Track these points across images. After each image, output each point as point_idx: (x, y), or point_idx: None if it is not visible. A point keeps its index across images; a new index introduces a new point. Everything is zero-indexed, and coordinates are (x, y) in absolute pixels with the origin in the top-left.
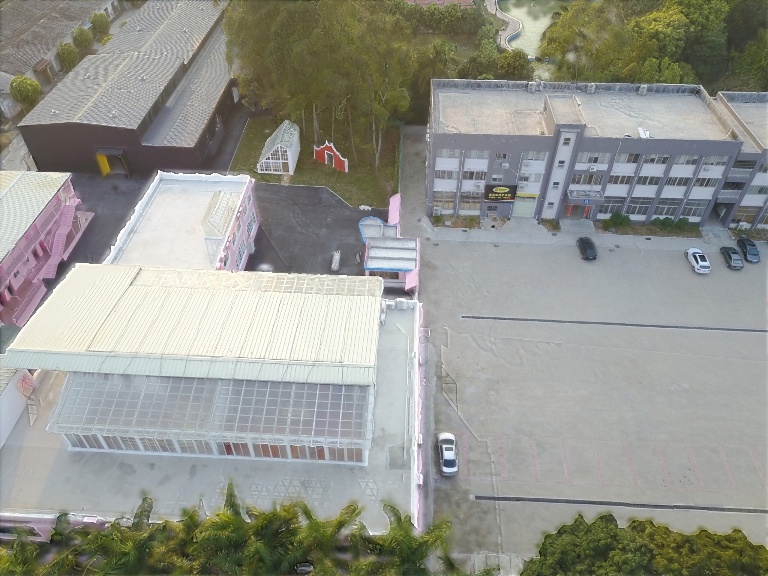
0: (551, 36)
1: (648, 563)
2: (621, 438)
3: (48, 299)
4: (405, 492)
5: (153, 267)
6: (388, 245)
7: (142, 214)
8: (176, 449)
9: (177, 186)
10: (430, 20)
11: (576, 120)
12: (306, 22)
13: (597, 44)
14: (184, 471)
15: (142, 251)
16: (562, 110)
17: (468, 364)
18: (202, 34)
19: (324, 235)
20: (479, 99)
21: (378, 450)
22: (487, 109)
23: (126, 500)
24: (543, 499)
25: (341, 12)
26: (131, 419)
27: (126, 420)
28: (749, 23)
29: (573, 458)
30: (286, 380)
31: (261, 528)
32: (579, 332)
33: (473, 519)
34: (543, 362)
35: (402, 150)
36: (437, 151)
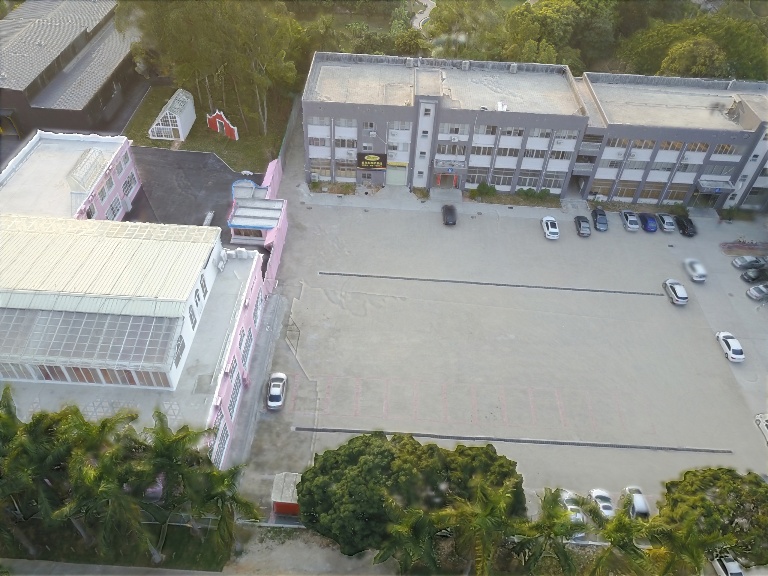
0: (433, 15)
1: (387, 464)
2: (441, 380)
3: None
4: (204, 413)
5: (5, 214)
6: (256, 205)
7: (15, 169)
8: None
9: (55, 145)
10: (345, 0)
11: (436, 92)
12: None
13: (473, 24)
14: None
15: (7, 203)
16: (426, 83)
17: (315, 314)
18: (111, 5)
19: (202, 197)
20: (358, 72)
21: (188, 378)
22: (363, 81)
23: None
24: (357, 431)
25: None
26: None
27: None
28: (641, 13)
29: (393, 396)
30: (102, 312)
31: (30, 426)
32: (426, 288)
33: (289, 447)
34: (386, 314)
35: (296, 121)
36: (308, 118)
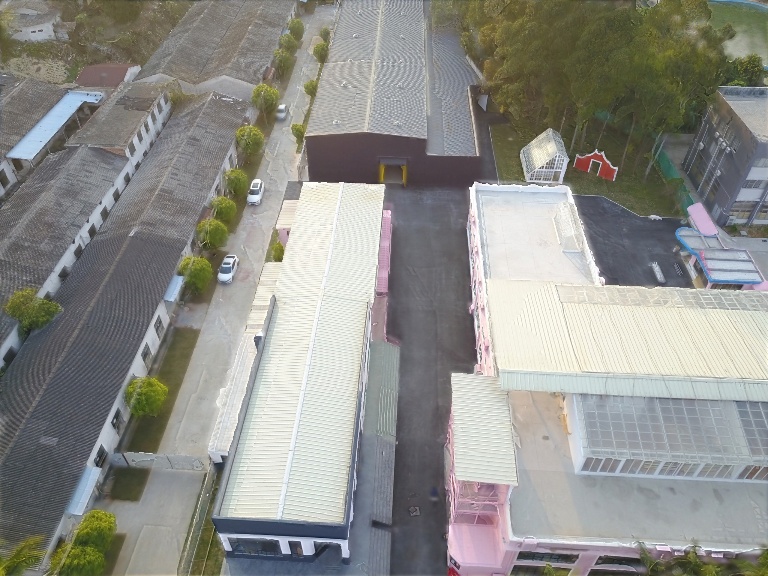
0: None
1: None
2: None
3: (493, 317)
4: None
5: (566, 283)
6: (719, 257)
7: (482, 227)
8: (694, 473)
9: (497, 197)
10: None
11: None
12: (625, 30)
13: None
14: (709, 496)
15: (508, 265)
16: None
17: None
18: (420, 40)
19: (630, 246)
20: None
21: None
22: None
23: (671, 527)
24: None
25: (675, 20)
26: (663, 443)
27: (659, 444)
28: None
29: None
30: None
31: None
32: None
33: None
34: None
35: None
36: (755, 161)
